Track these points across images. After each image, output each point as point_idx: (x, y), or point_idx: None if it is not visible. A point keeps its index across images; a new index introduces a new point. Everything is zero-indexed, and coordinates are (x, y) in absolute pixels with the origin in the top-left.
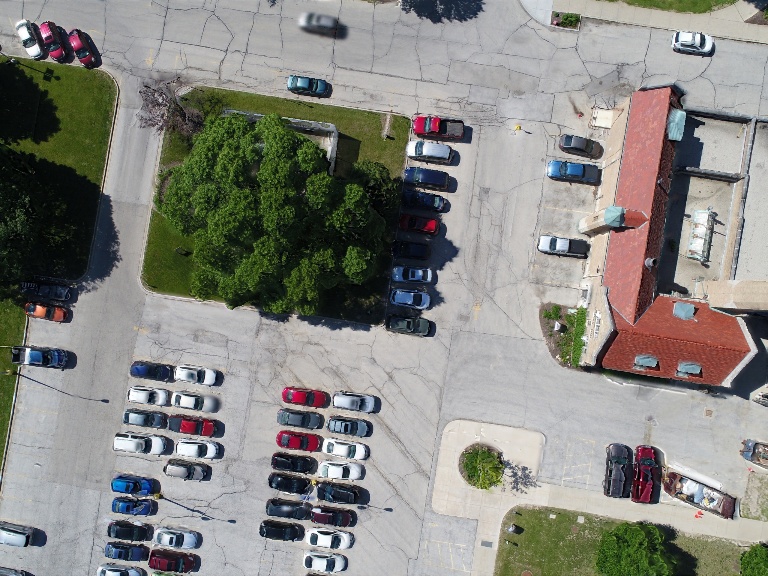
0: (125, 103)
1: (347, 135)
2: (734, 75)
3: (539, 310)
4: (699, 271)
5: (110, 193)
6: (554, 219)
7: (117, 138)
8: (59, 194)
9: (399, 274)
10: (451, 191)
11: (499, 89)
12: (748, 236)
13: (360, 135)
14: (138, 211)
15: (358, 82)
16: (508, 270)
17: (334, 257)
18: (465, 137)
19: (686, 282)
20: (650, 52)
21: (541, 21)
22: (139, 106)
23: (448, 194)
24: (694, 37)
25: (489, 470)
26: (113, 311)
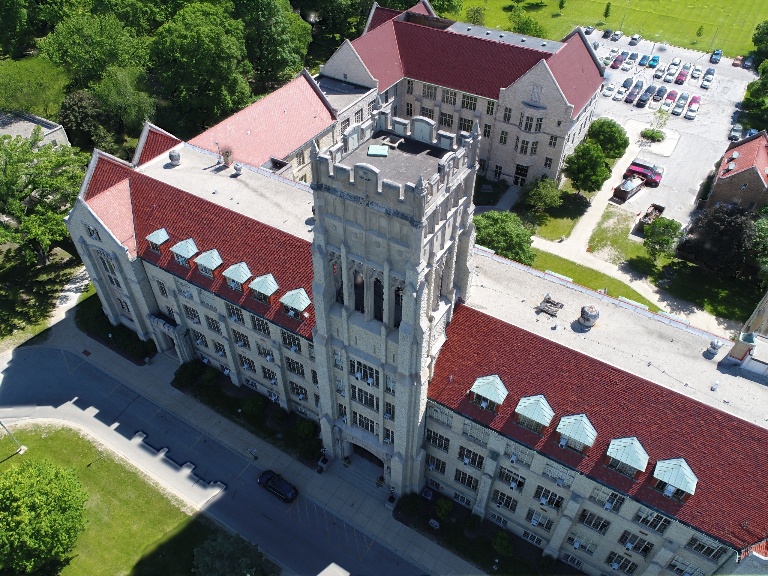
0: None
1: None
2: None
3: None
4: None
5: None
6: None
7: None
8: None
9: None
10: None
11: None
12: None
13: None
14: None
15: None
16: None
17: None
18: None
19: None
20: None
21: None
22: None
23: None
24: None
25: (668, 113)
26: (738, 74)
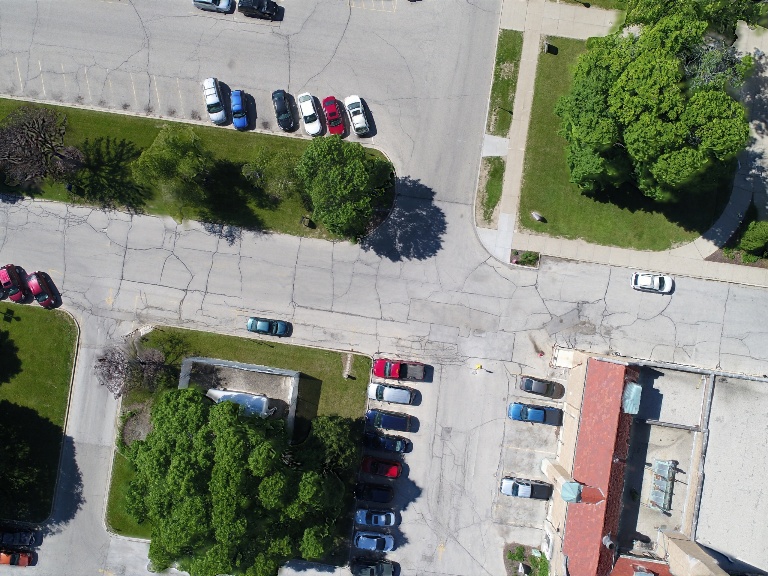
0: (86, 343)
1: (308, 375)
2: (694, 313)
3: (503, 550)
4: (661, 519)
5: (73, 434)
6: (517, 459)
7: (79, 379)
8: (22, 436)
9: (362, 518)
10: (413, 431)
11: (459, 328)
12: (708, 491)
13: (321, 375)
14: (101, 452)
15: (318, 321)
16: (471, 510)
17: (291, 541)
18: (426, 376)
19: (648, 531)
20: (610, 290)
21: (500, 259)
22: (100, 347)
23: (410, 434)
24: (653, 281)
25: None
26: (78, 553)
